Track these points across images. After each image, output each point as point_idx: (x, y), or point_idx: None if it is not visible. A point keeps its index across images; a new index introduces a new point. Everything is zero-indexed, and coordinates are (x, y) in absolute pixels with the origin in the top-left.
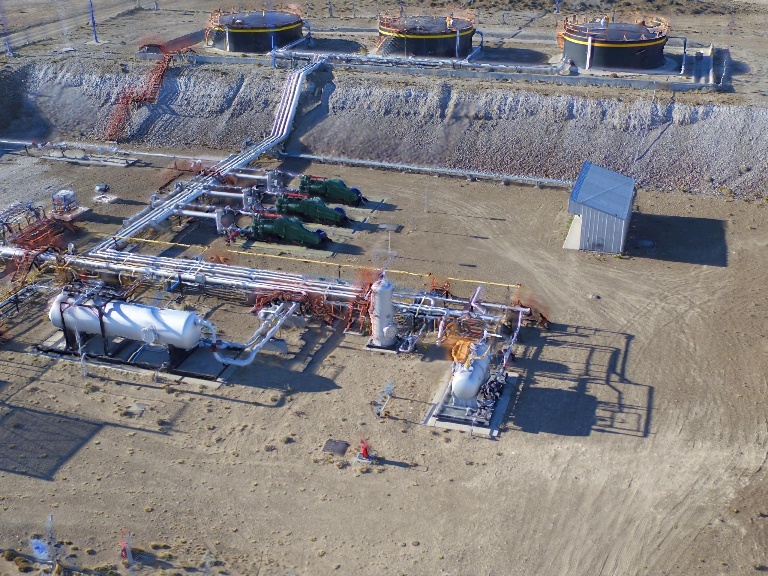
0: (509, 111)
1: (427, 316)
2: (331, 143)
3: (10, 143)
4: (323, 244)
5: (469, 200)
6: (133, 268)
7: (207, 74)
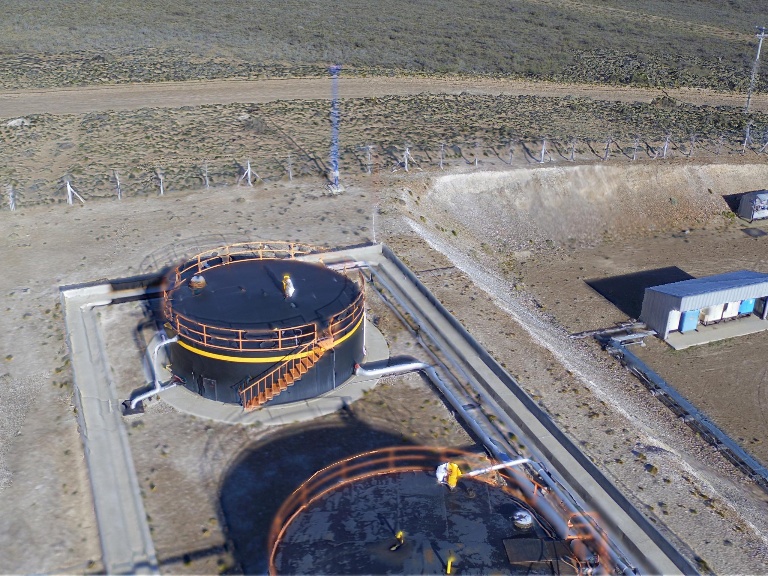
0: None
1: None
2: None
3: None
4: None
5: None
6: None
7: None
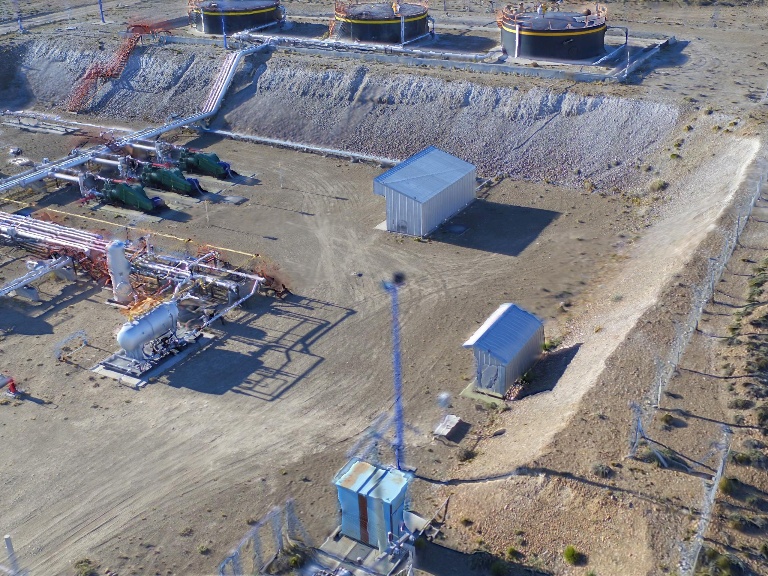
0: (411, 96)
1: (174, 278)
2: (249, 121)
3: None
4: (157, 210)
5: (332, 179)
6: None
7: (165, 53)
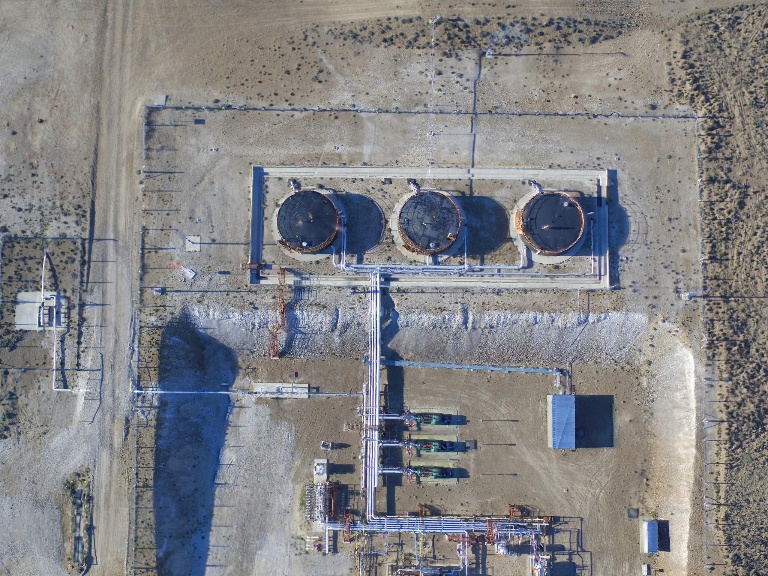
0: None
1: None
2: (408, 348)
3: (218, 374)
4: (451, 475)
5: (497, 400)
6: (393, 530)
7: (313, 309)
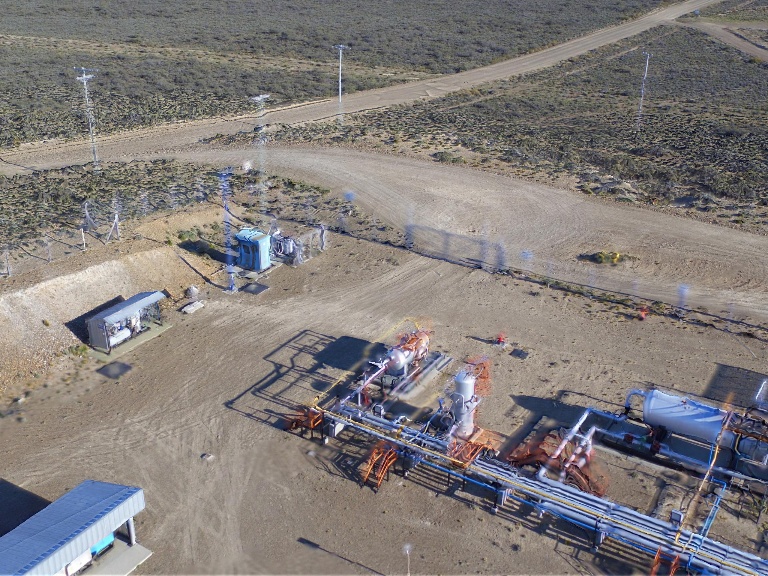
0: None
1: None
2: None
3: None
4: None
5: None
6: None
7: None
